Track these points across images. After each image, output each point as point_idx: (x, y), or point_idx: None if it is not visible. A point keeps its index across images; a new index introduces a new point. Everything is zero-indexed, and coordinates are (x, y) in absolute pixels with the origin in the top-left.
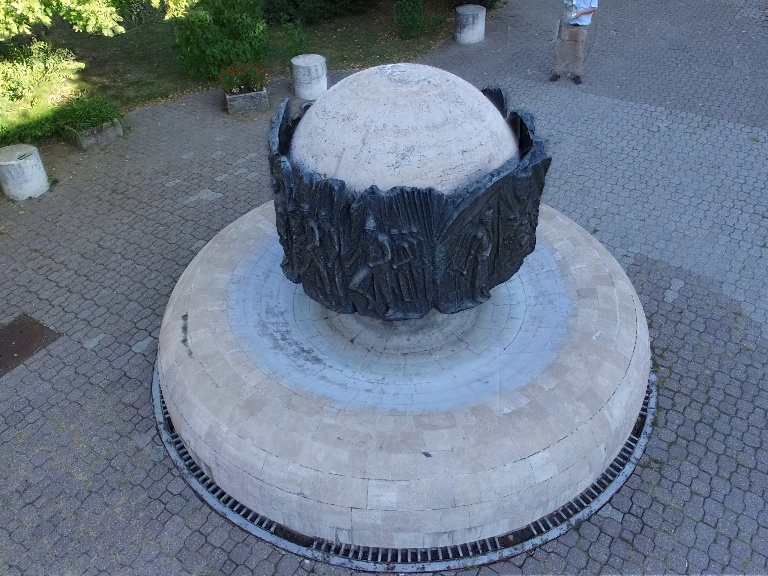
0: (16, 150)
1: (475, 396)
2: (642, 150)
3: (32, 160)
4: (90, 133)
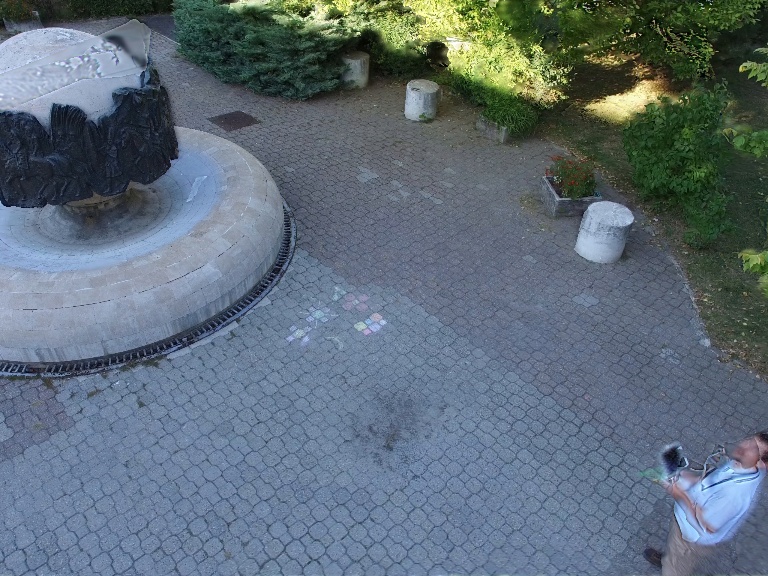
0: (429, 86)
1: None
2: (303, 570)
3: (415, 94)
4: (485, 121)
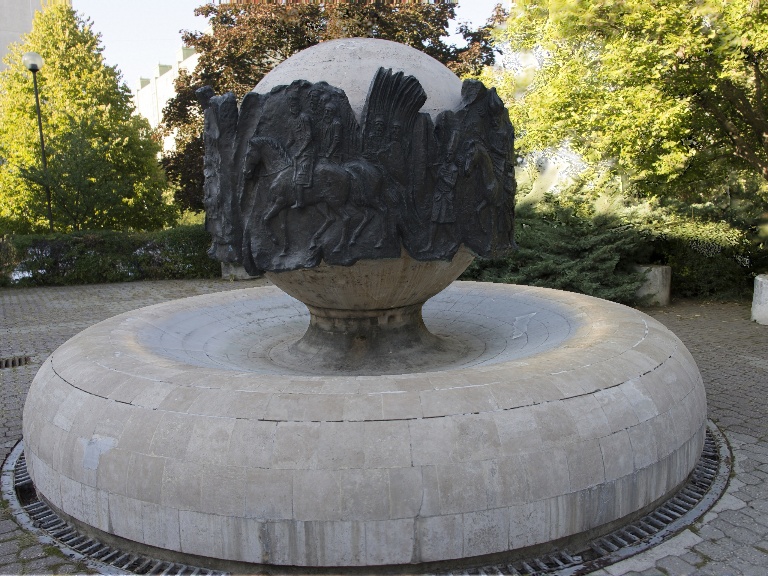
0: None
1: (171, 323)
2: None
3: None
4: None
